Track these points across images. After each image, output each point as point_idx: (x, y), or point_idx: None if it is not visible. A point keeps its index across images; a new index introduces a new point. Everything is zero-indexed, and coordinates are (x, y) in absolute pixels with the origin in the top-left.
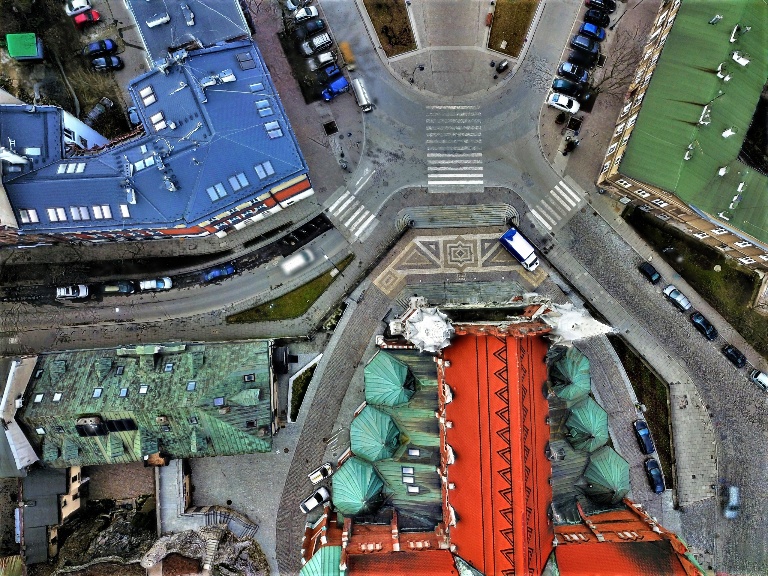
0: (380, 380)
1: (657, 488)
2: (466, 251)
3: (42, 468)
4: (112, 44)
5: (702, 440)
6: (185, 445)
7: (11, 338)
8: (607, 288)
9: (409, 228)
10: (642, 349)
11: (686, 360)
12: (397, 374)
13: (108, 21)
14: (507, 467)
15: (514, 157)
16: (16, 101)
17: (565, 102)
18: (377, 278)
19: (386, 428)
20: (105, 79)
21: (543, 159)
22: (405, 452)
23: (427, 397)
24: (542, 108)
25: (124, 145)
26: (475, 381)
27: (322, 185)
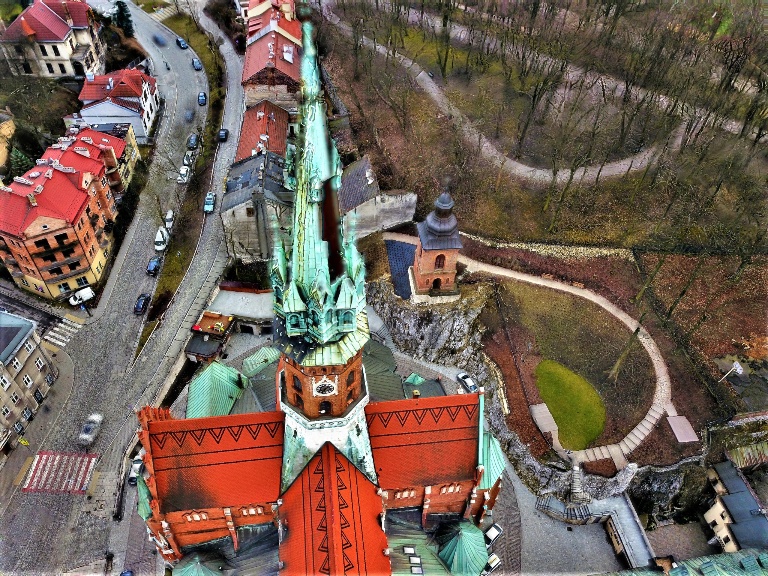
0: None
1: None
2: None
3: (764, 547)
4: None
5: None
6: None
7: None
8: None
9: None
10: None
11: None
12: None
13: None
14: (347, 572)
15: None
16: None
17: None
18: None
19: None
20: None
21: None
22: None
23: None
24: None
25: None
26: None
27: None
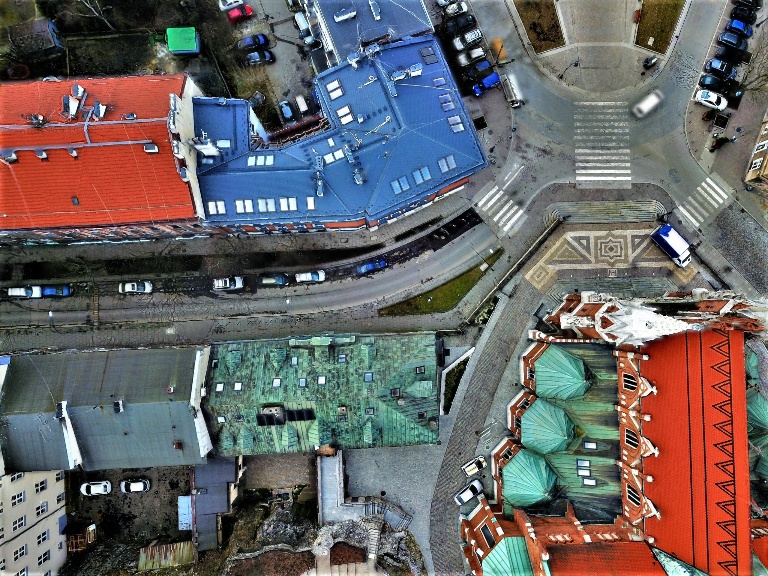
0: (554, 373)
1: None
2: (616, 247)
3: (213, 456)
4: (264, 39)
5: None
6: (355, 435)
7: (167, 328)
8: (755, 285)
9: (560, 223)
10: None
11: None
12: (574, 367)
13: (259, 16)
14: (728, 460)
15: (661, 153)
16: (201, 94)
17: (714, 99)
18: (528, 273)
19: (563, 421)
20: (257, 73)
21: (690, 156)
22: (580, 445)
23: (605, 391)
24: (689, 105)
25: (309, 138)
26: (684, 374)
27: (471, 180)
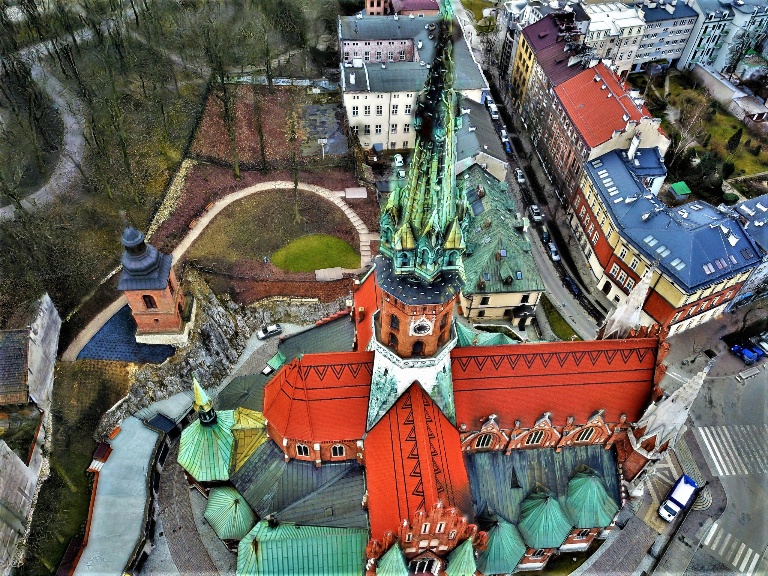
0: None
1: None
2: None
3: None
4: None
5: None
6: None
7: None
8: None
9: None
10: None
11: None
12: None
13: None
14: None
15: (760, 505)
16: None
17: None
18: None
19: None
20: None
21: None
22: None
23: None
24: None
25: None
26: None
27: None
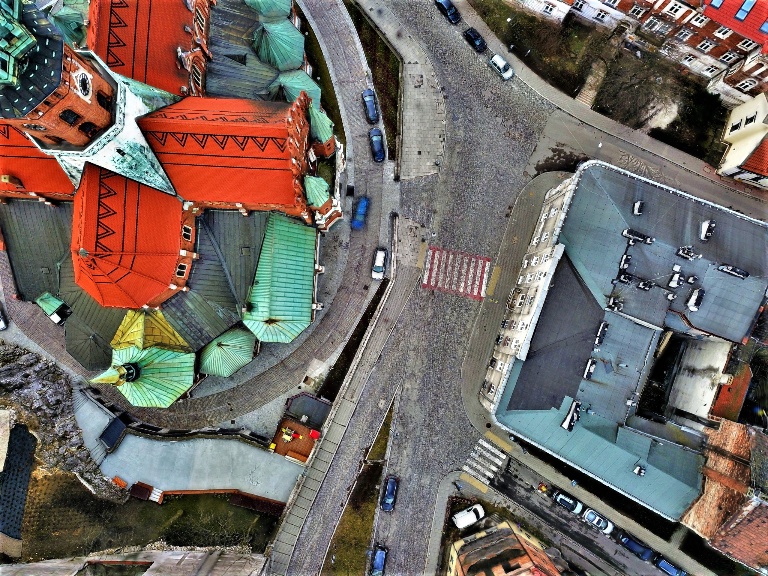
0: None
1: (377, 156)
2: None
3: None
4: None
5: (433, 119)
6: None
7: None
8: None
9: None
10: (384, 27)
11: (427, 42)
12: None
13: None
14: None
15: None
16: None
17: None
18: None
19: None
20: None
21: None
22: None
23: None
24: None
25: None
26: None
27: None
